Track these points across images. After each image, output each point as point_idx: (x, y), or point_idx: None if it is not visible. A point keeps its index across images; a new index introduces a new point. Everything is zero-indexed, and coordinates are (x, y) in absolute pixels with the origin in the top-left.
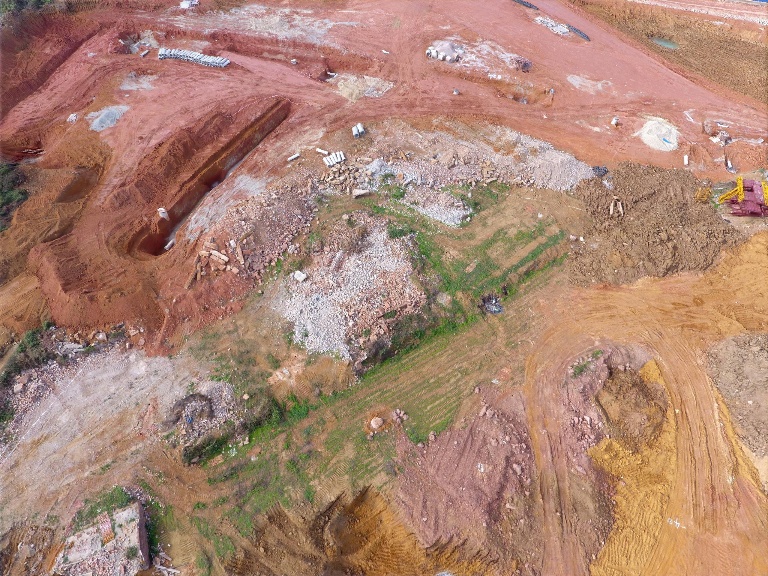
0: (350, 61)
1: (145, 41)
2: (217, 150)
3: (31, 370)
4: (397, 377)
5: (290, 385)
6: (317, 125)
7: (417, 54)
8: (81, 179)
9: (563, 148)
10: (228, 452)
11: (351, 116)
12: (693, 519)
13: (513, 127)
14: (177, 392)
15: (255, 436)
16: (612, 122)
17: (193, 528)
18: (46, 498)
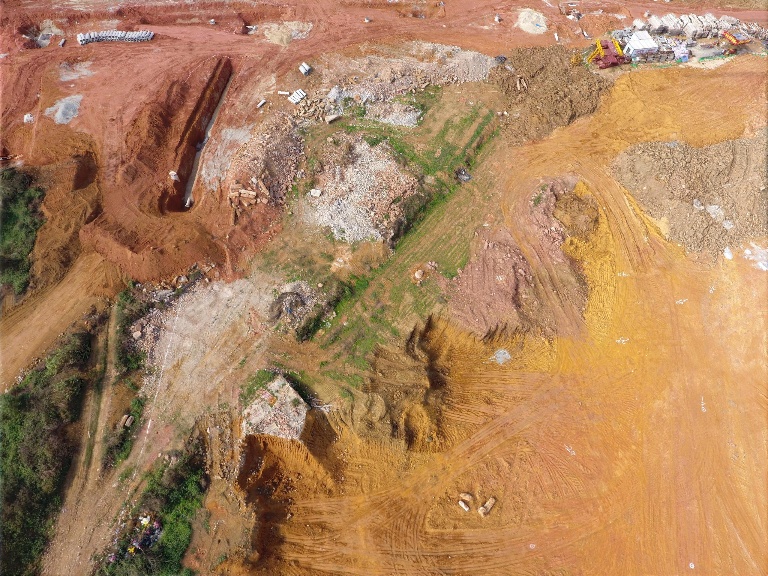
0: (263, 11)
1: (47, 32)
2: (190, 114)
3: (139, 320)
4: (419, 242)
5: (347, 269)
6: (266, 73)
7: None
8: (83, 166)
9: (468, 48)
10: (325, 326)
11: (291, 59)
12: (632, 269)
13: (424, 39)
14: (267, 299)
15: (339, 310)
16: (495, 19)
17: (326, 378)
18: (209, 396)
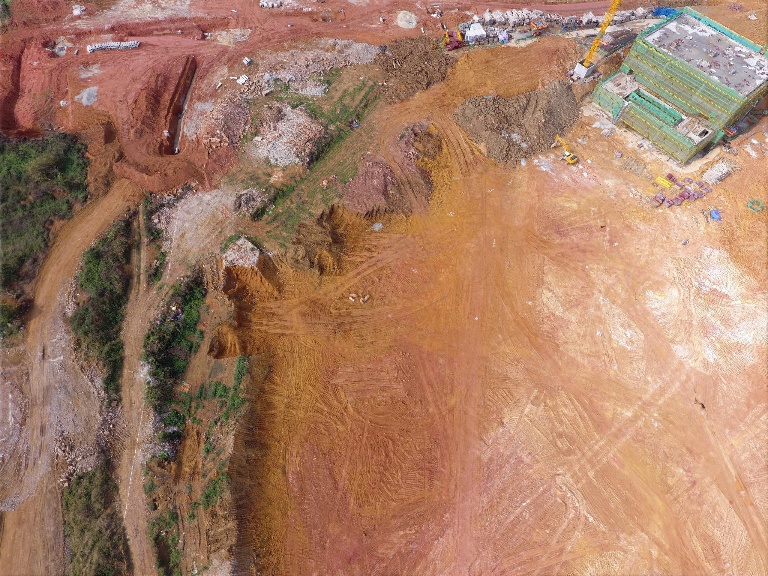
0: (215, 22)
1: (61, 45)
2: (172, 95)
3: (156, 213)
4: (326, 165)
5: (280, 181)
6: (221, 65)
7: (255, 7)
8: (107, 130)
9: (360, 41)
10: (268, 213)
11: (237, 55)
12: (461, 174)
13: (330, 37)
14: (232, 199)
15: (276, 204)
16: (380, 20)
17: (270, 239)
18: (203, 249)
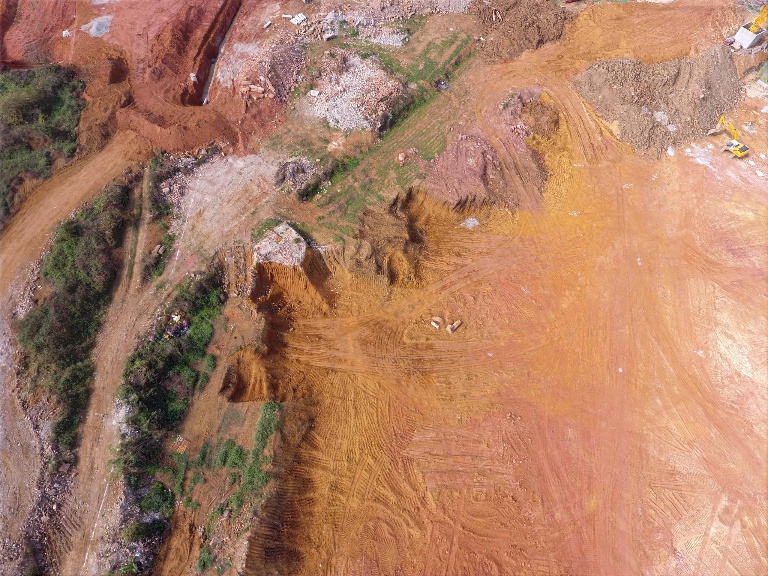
0: None
1: None
2: (206, 31)
3: (168, 180)
4: (403, 134)
5: (341, 150)
6: (272, 1)
7: None
8: (116, 67)
9: None
10: (321, 192)
11: None
12: (586, 161)
13: None
14: (273, 169)
15: (333, 181)
16: None
17: (323, 228)
18: (226, 235)
